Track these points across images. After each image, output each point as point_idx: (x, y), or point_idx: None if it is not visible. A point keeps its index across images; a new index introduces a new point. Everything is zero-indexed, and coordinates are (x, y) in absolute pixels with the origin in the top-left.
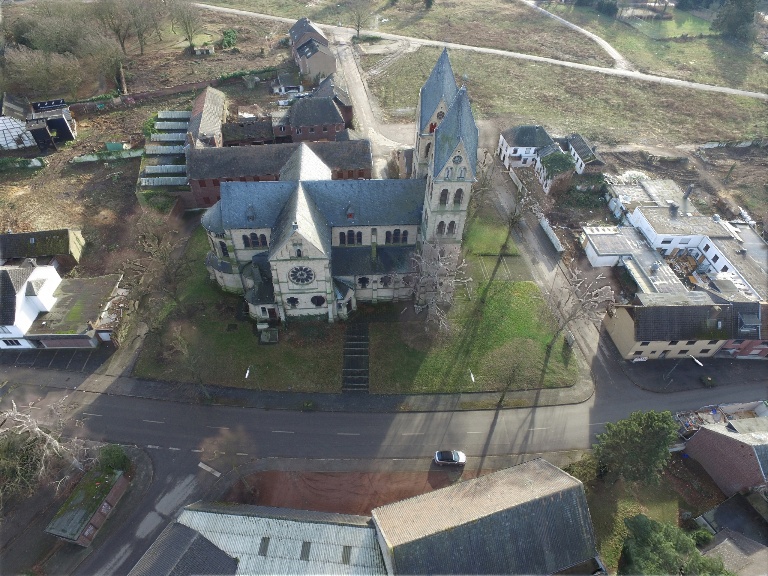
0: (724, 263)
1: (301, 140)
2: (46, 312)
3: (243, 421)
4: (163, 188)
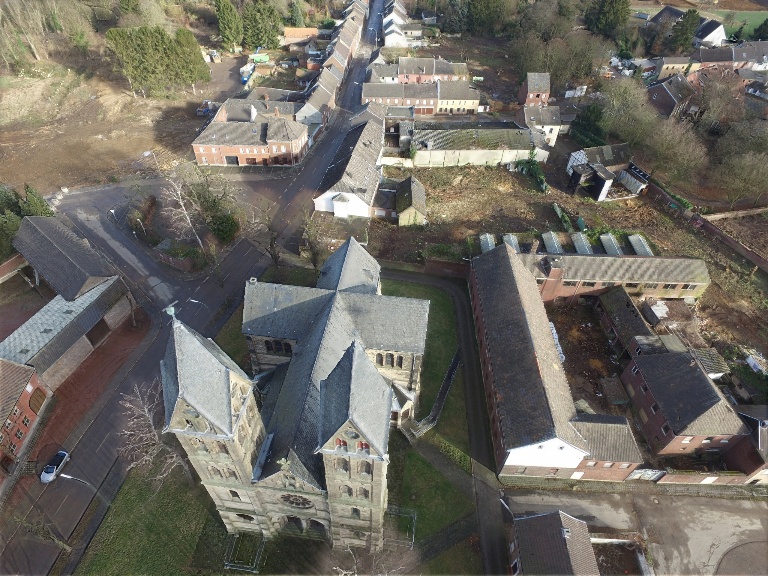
0: None
1: (630, 381)
2: (334, 215)
3: (196, 323)
4: (477, 250)
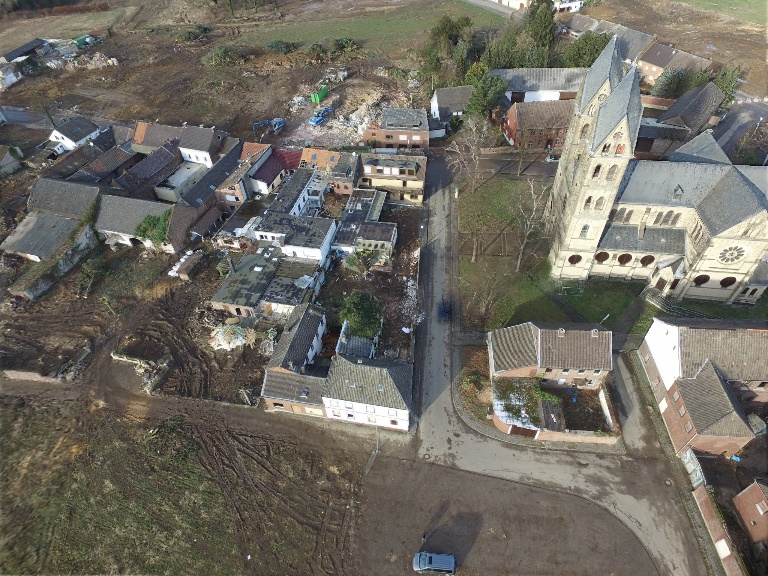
0: None
1: None
2: None
3: None
4: None
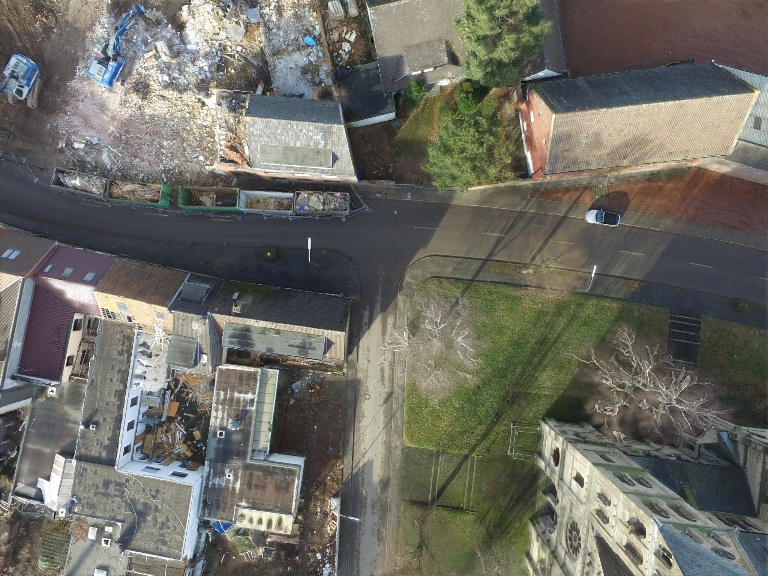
0: (130, 411)
1: None
2: None
3: None
4: None
